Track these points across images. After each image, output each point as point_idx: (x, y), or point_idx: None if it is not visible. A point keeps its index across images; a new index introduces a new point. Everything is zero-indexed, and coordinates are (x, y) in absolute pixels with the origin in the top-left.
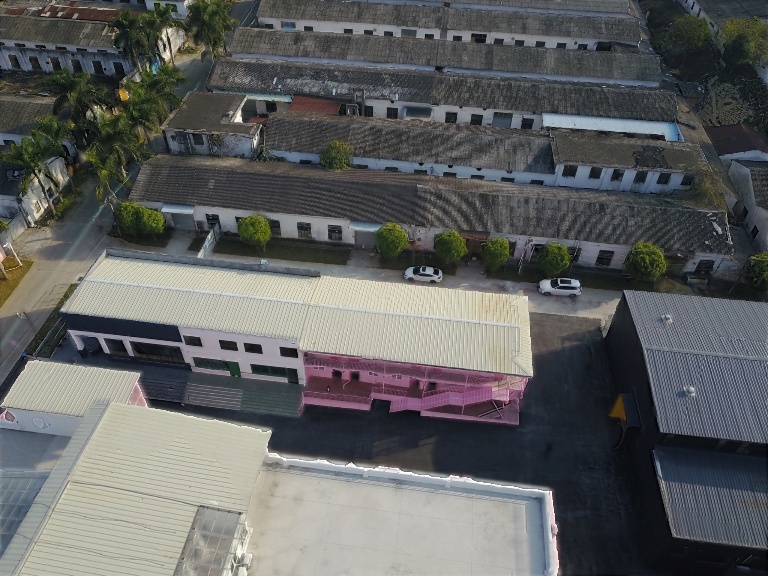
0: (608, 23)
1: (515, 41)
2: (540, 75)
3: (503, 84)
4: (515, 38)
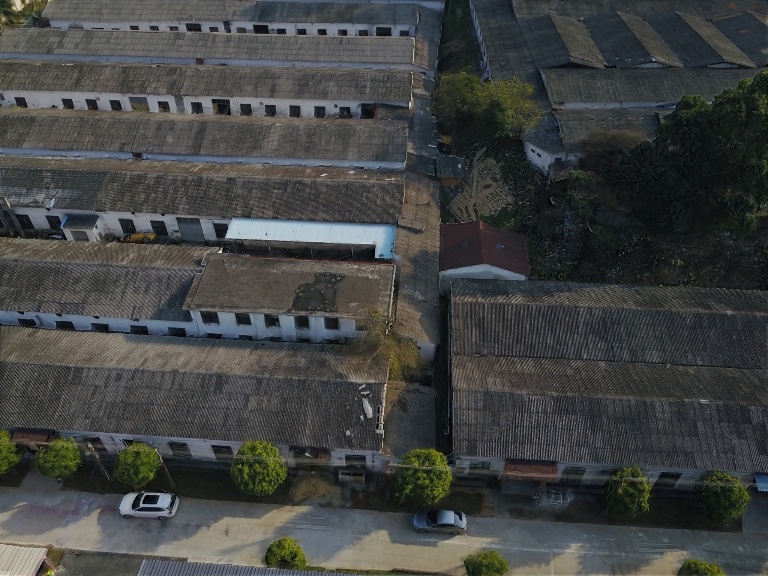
0: (375, 80)
1: (265, 106)
2: (259, 159)
3: (191, 179)
4: (264, 103)
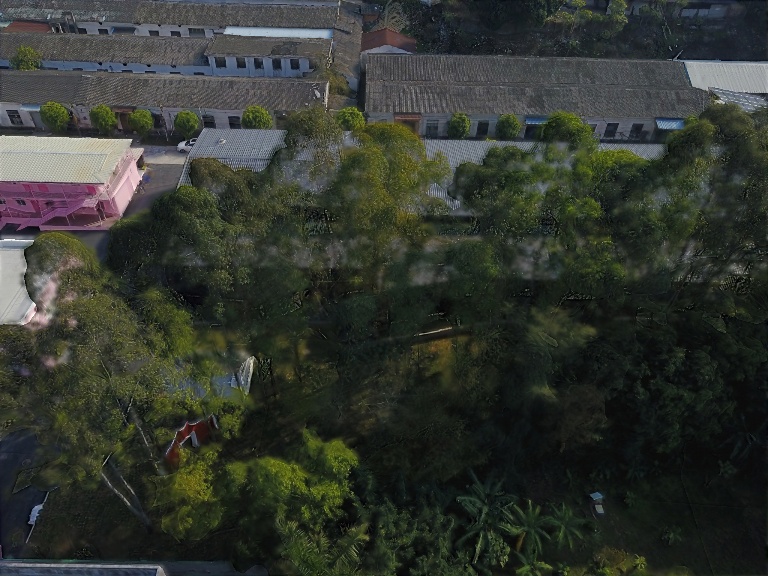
0: None
1: None
2: (240, 0)
3: (197, 5)
4: None
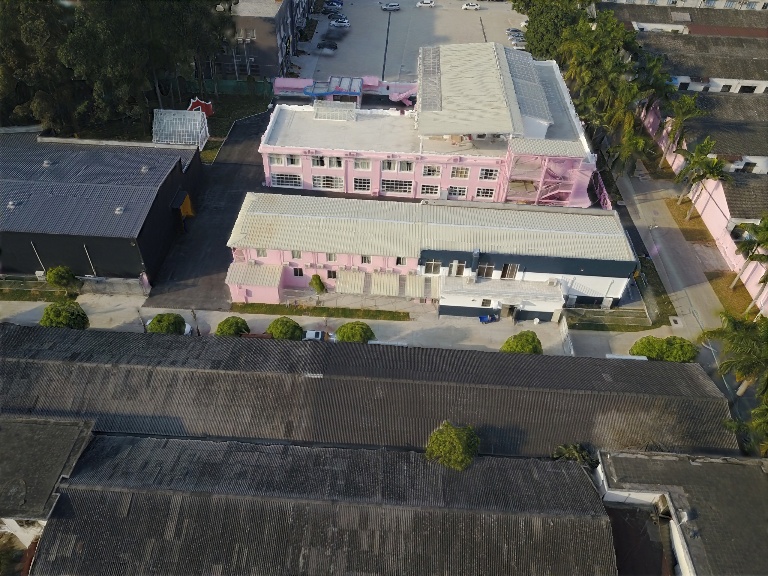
0: None
1: None
2: None
3: None
4: None
